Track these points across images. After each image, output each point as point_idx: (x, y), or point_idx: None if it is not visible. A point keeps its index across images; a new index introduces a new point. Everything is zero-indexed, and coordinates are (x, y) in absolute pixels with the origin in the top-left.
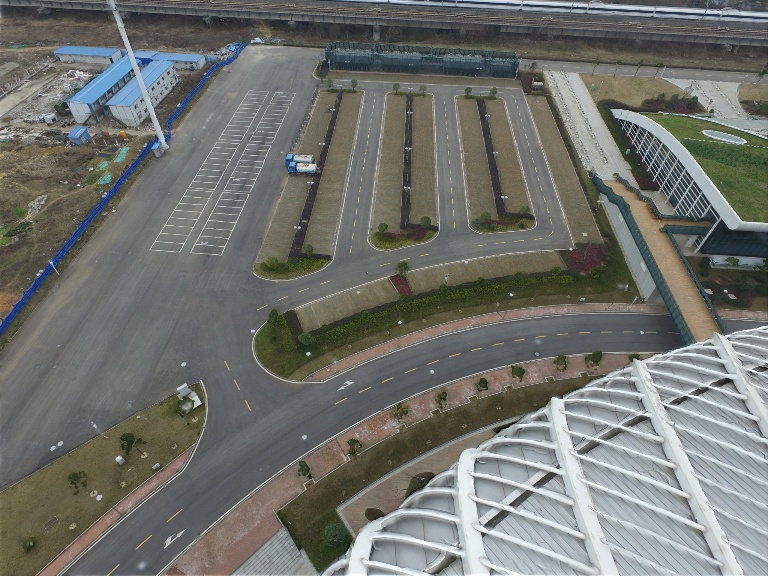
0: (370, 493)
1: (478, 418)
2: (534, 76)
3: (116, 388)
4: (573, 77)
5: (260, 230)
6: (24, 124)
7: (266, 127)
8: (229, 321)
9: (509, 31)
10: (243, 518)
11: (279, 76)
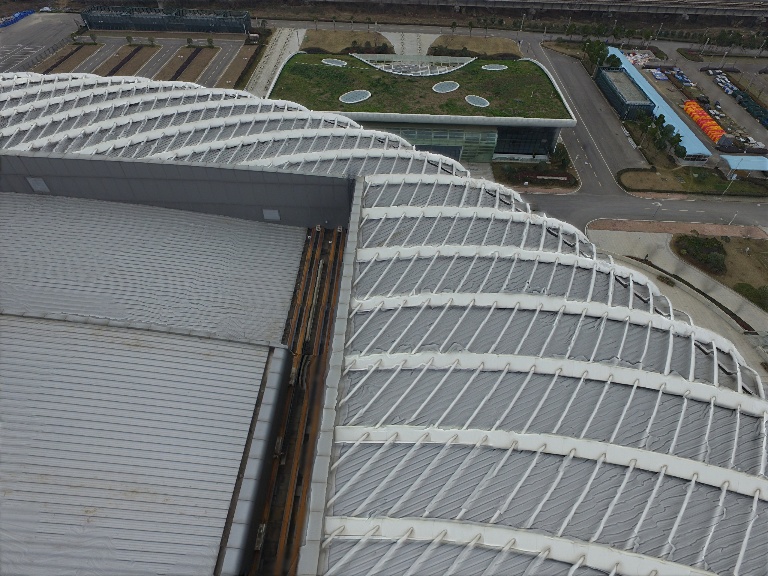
0: None
1: None
2: (263, 31)
3: None
4: (299, 32)
5: None
6: None
7: None
8: None
9: None
10: None
11: (42, 35)
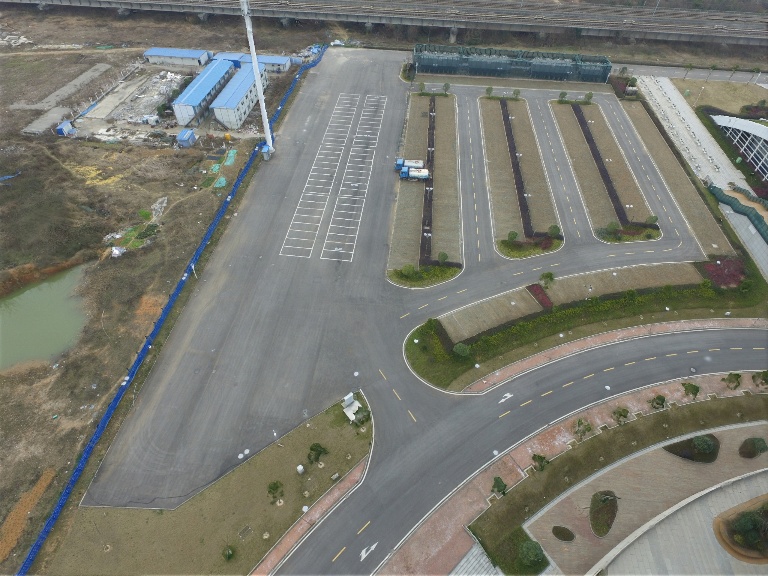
0: (553, 510)
1: (647, 435)
2: (625, 81)
3: (279, 395)
4: (664, 82)
5: (384, 236)
6: (128, 125)
7: (366, 131)
8: (375, 329)
9: (590, 34)
10: (434, 533)
11: (367, 79)
